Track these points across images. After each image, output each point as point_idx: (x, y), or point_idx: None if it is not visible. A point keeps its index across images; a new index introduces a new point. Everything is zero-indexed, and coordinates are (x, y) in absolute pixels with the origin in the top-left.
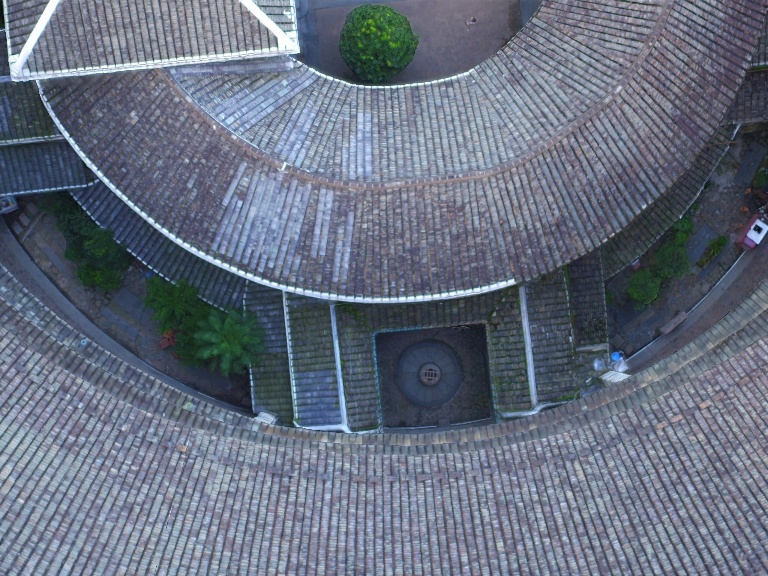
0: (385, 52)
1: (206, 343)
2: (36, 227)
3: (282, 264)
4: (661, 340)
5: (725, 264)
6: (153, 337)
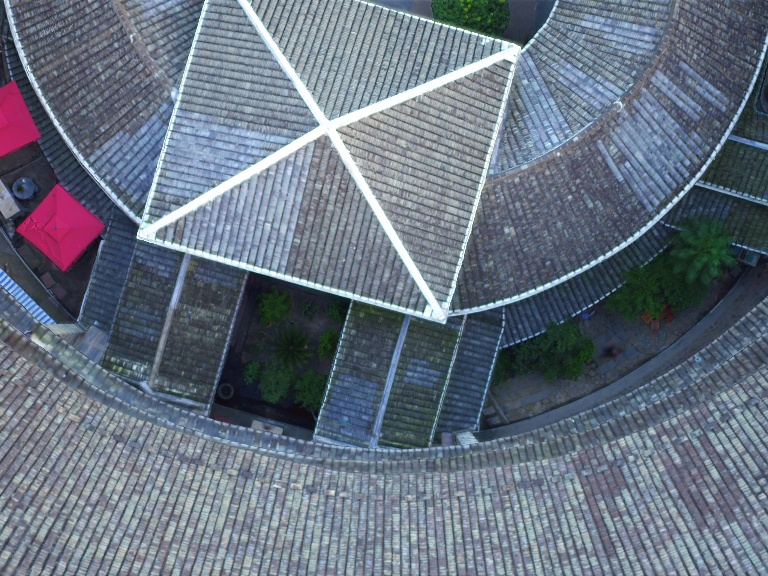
0: (491, 0)
1: (703, 269)
2: (499, 404)
3: (691, 152)
4: None
5: None
6: (643, 335)
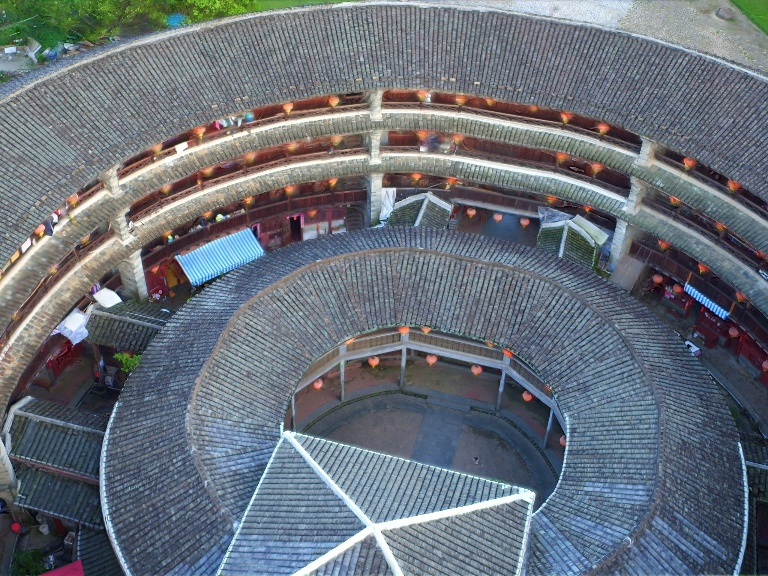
0: None
1: None
2: None
3: None
4: (763, 429)
5: None
6: None
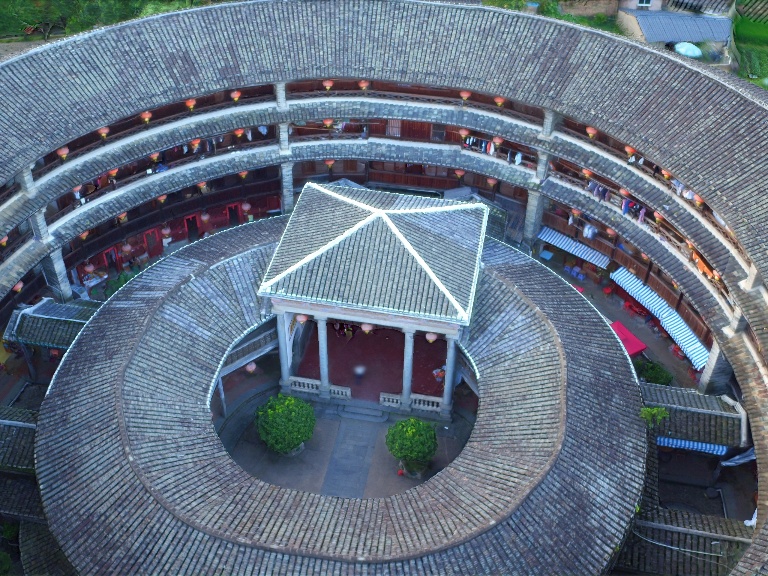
0: None
1: None
2: None
3: None
4: None
5: None
6: None
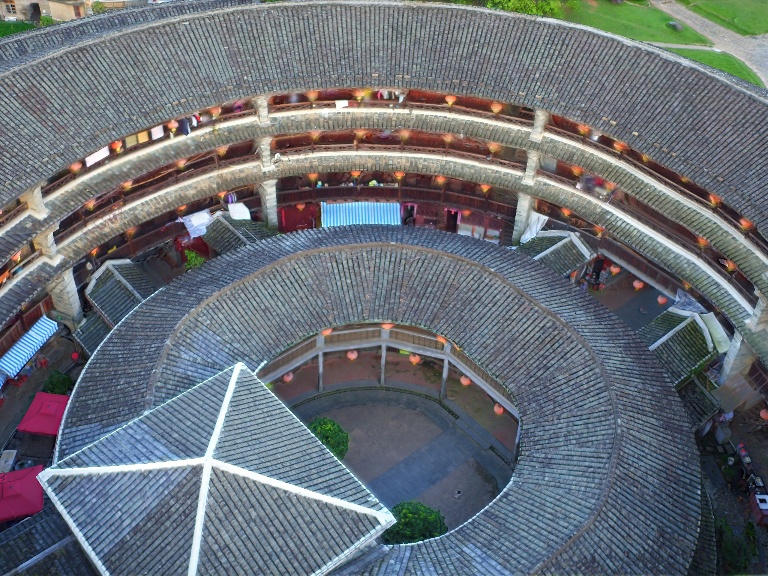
0: (428, 528)
1: None
2: None
3: None
4: None
5: (767, 543)
6: None
